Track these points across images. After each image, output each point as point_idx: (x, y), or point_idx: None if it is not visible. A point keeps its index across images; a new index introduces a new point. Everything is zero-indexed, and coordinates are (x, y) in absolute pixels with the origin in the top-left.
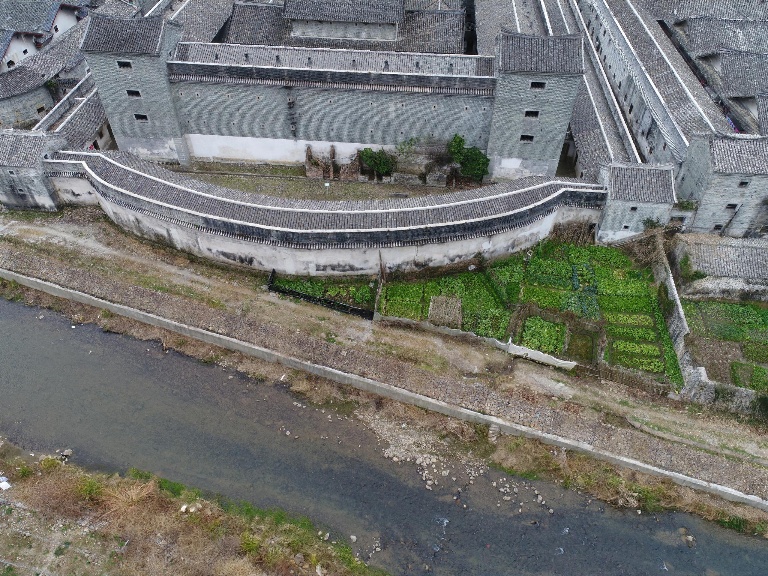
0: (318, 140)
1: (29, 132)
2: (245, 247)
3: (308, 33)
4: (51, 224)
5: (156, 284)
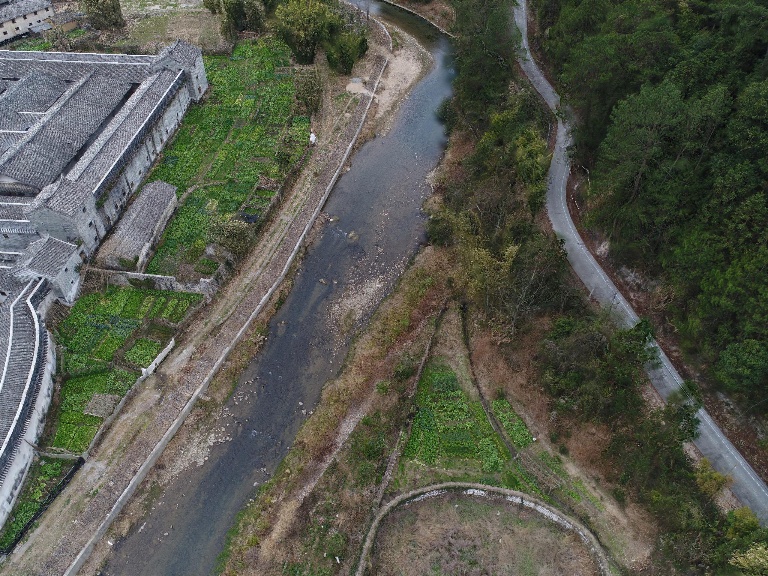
0: None
1: None
2: None
3: None
4: None
5: None
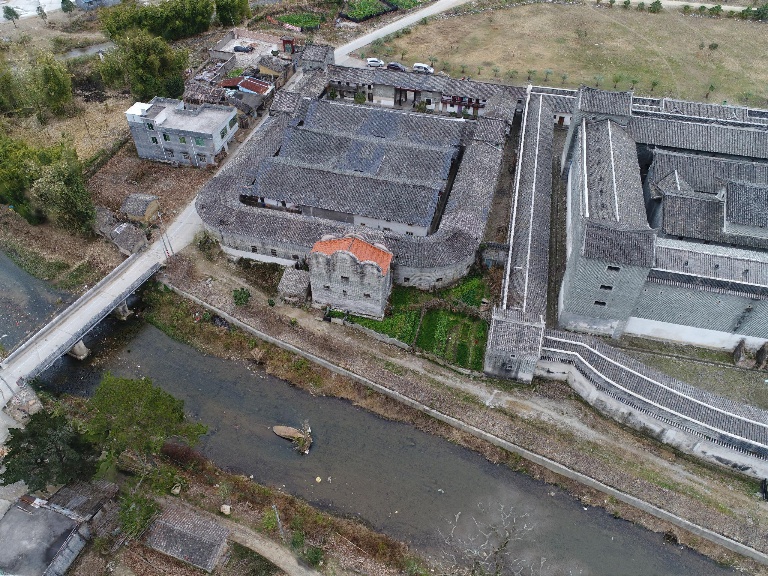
0: (756, 336)
1: (532, 323)
2: (749, 460)
3: (741, 231)
4: (531, 398)
5: (660, 480)
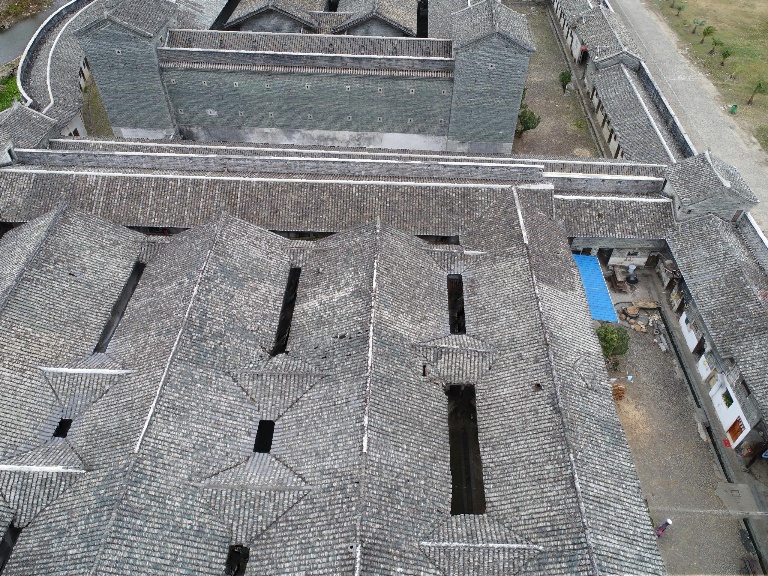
0: None
1: None
2: None
3: None
4: None
5: None
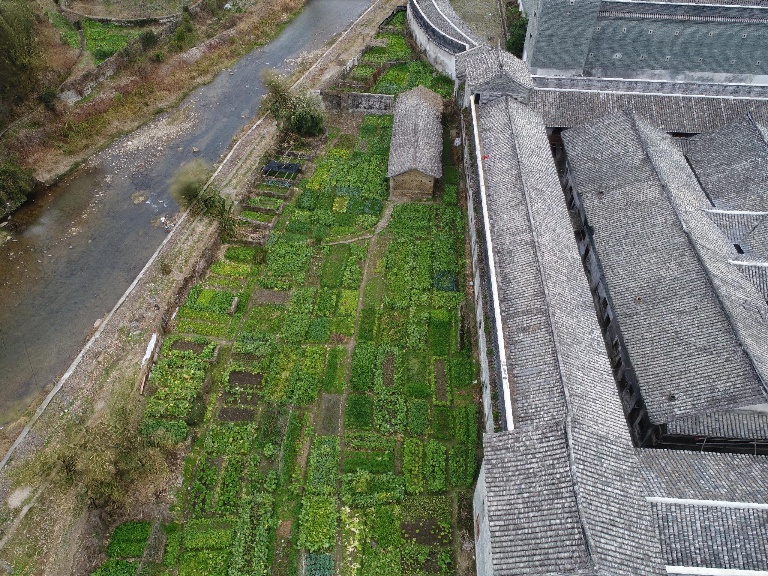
0: None
1: None
2: None
3: None
4: None
5: None
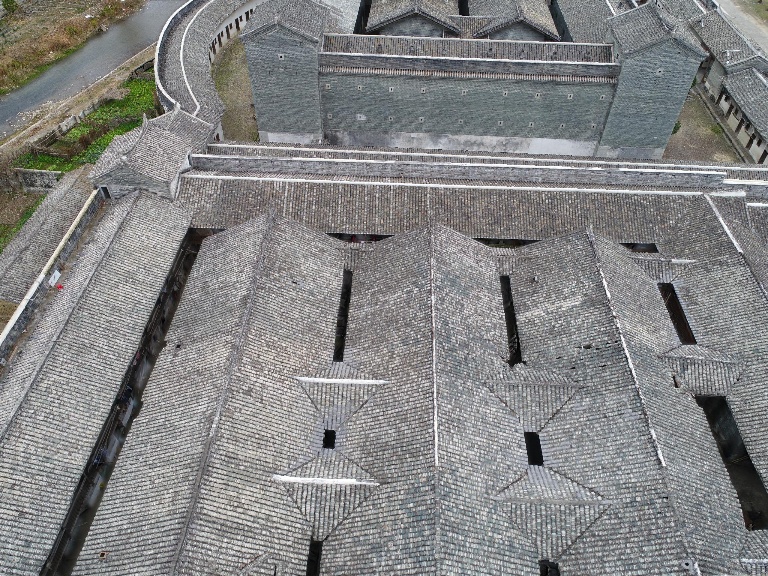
0: None
1: None
2: None
3: None
4: None
5: None
